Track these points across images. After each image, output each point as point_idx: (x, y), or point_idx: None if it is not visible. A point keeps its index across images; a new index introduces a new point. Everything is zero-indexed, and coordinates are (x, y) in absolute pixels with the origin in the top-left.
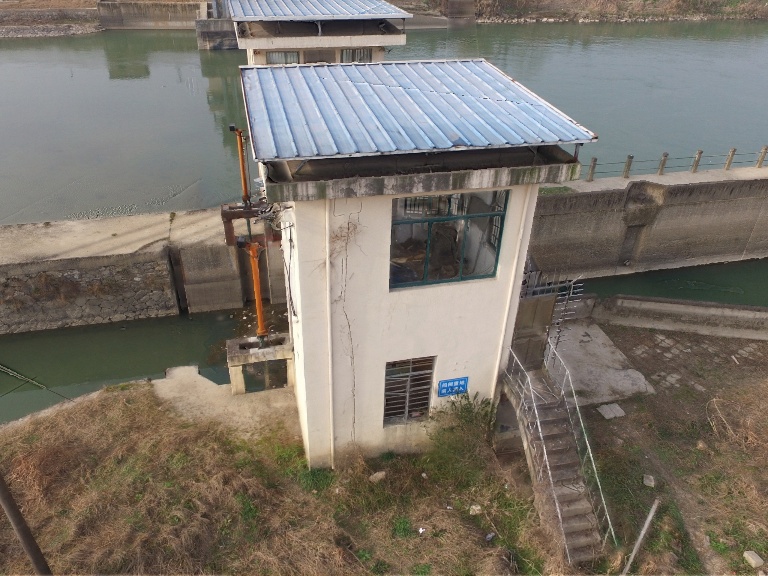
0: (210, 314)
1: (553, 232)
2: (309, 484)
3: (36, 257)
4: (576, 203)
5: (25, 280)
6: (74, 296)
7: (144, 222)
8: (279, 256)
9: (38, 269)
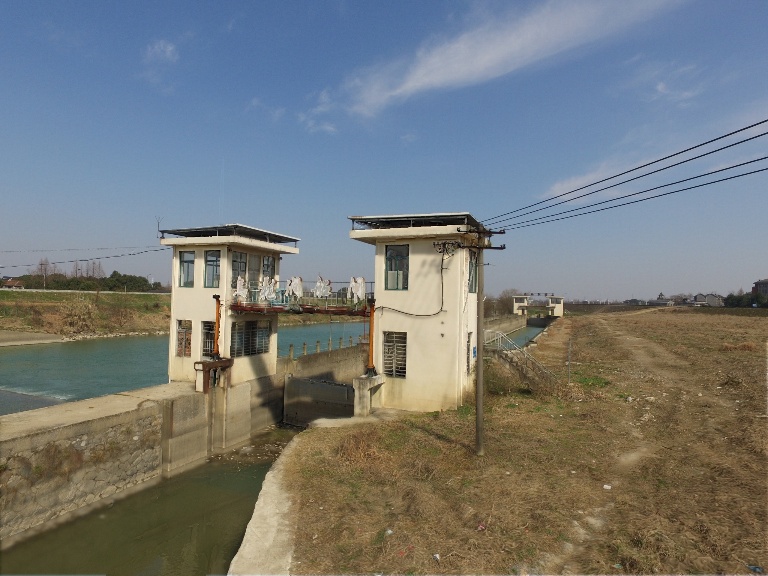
0: (187, 466)
1: (343, 371)
2: (463, 414)
3: (39, 429)
4: (348, 353)
5: (28, 457)
6: (75, 469)
7: (101, 400)
8: (232, 401)
9: (48, 439)
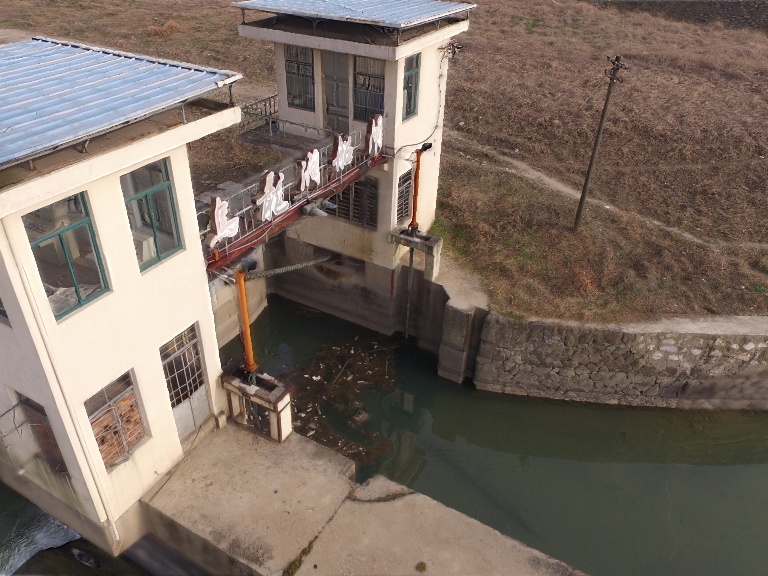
0: None
1: None
2: None
3: None
4: None
5: None
6: None
7: None
8: None
9: None
